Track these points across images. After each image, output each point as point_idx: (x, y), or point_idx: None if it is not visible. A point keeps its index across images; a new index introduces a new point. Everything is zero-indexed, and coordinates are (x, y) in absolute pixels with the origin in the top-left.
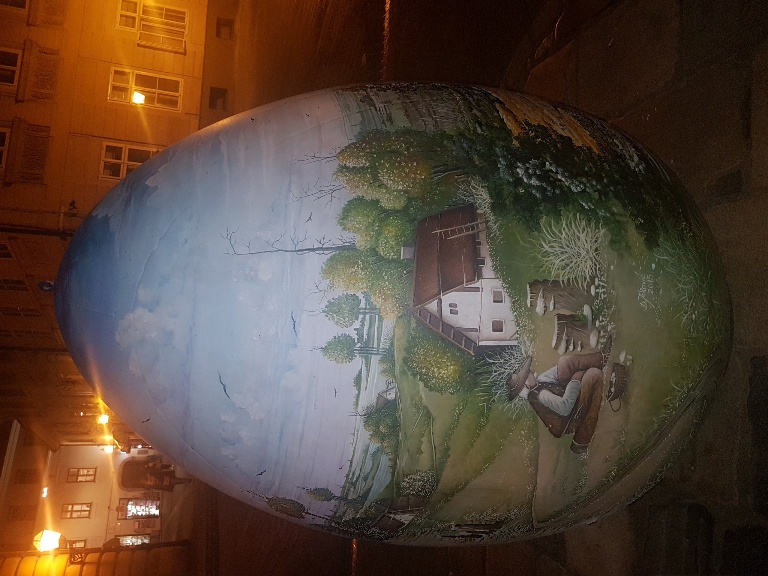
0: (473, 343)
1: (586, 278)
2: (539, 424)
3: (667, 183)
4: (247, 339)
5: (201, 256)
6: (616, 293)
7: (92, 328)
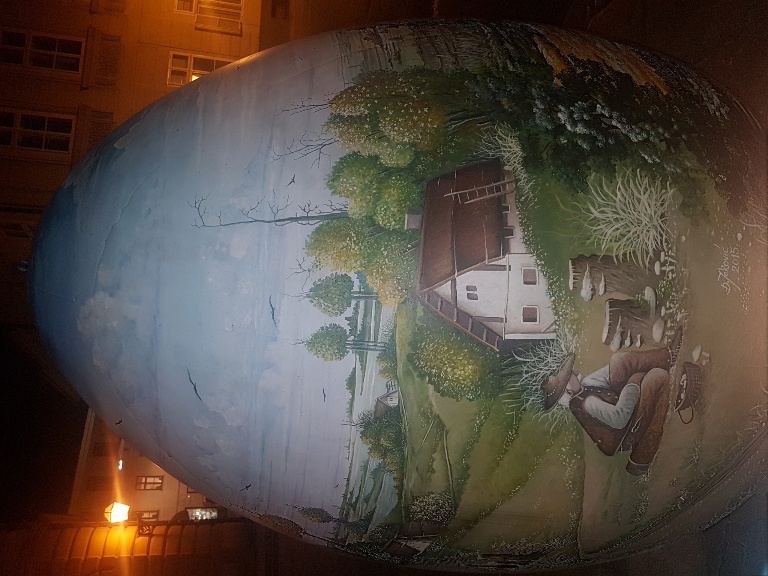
0: (497, 336)
1: (648, 252)
2: (585, 439)
3: (758, 131)
4: (218, 330)
5: (166, 229)
6: (689, 272)
7: (56, 315)
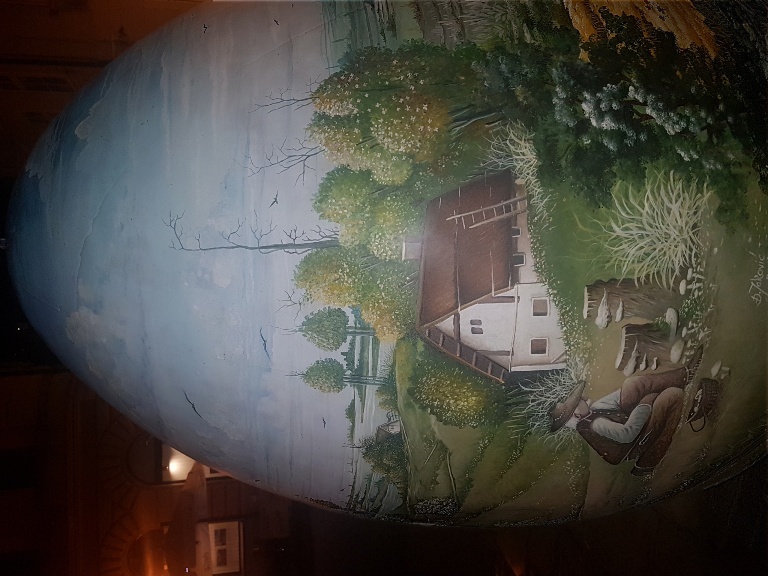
0: (503, 369)
1: (674, 271)
2: (590, 453)
3: None
4: (210, 358)
5: (142, 249)
6: (717, 287)
7: (44, 317)
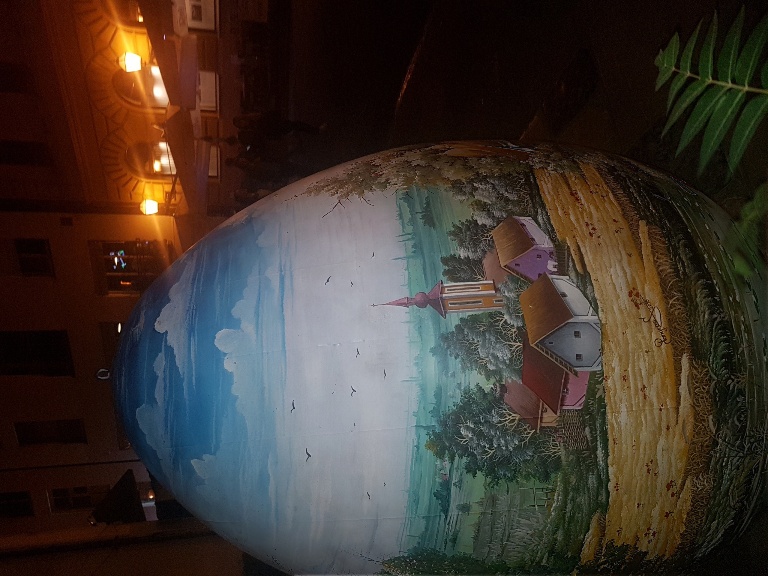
0: None
1: None
2: None
3: None
4: None
5: None
6: None
7: None
